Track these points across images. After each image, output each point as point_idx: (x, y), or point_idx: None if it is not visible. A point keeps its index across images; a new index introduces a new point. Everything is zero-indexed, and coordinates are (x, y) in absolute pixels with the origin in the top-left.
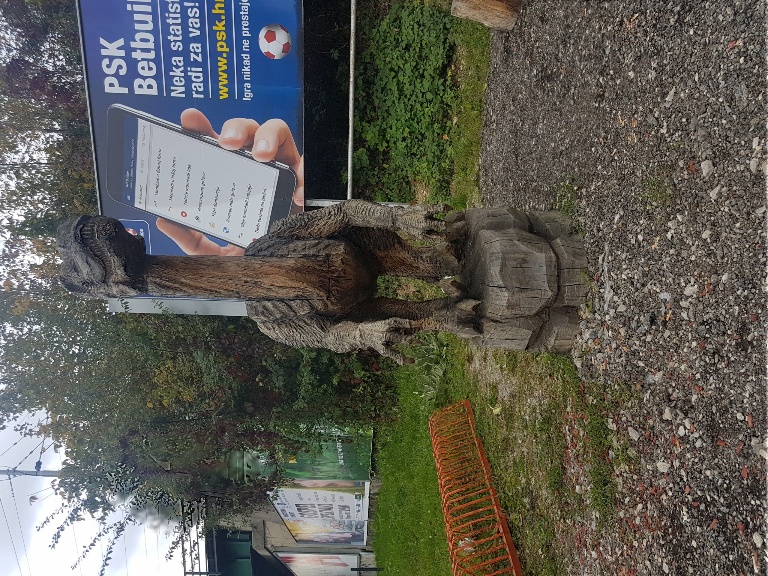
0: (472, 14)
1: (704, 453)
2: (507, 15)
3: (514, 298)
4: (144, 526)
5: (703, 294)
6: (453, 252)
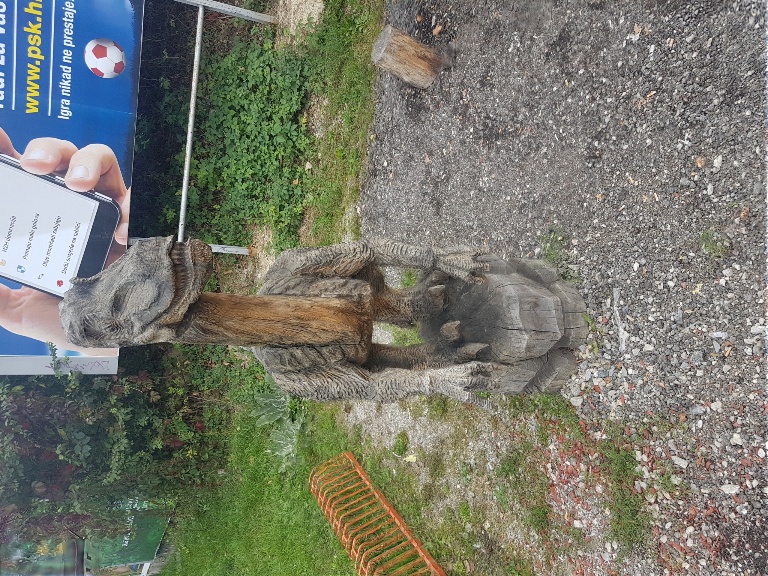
0: (396, 67)
1: None
2: (427, 74)
3: (531, 341)
4: None
5: None
6: (443, 296)
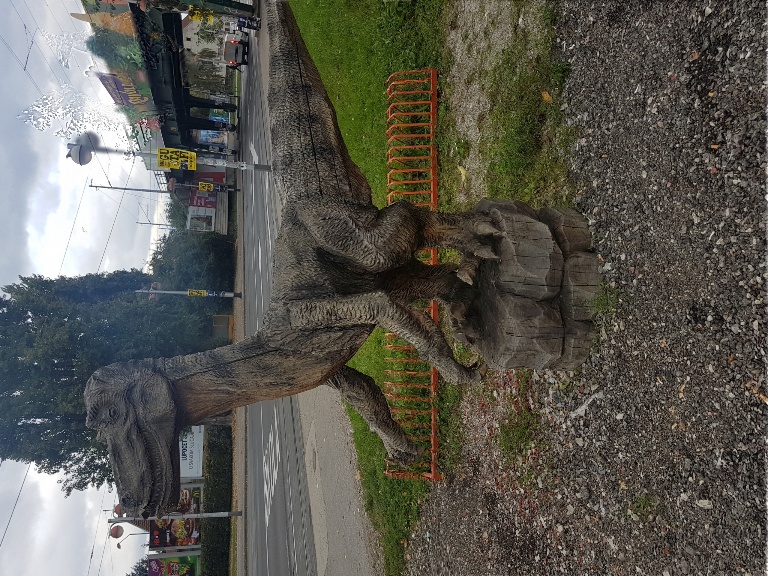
0: None
1: None
2: None
3: None
4: (91, 152)
5: (614, 567)
6: None
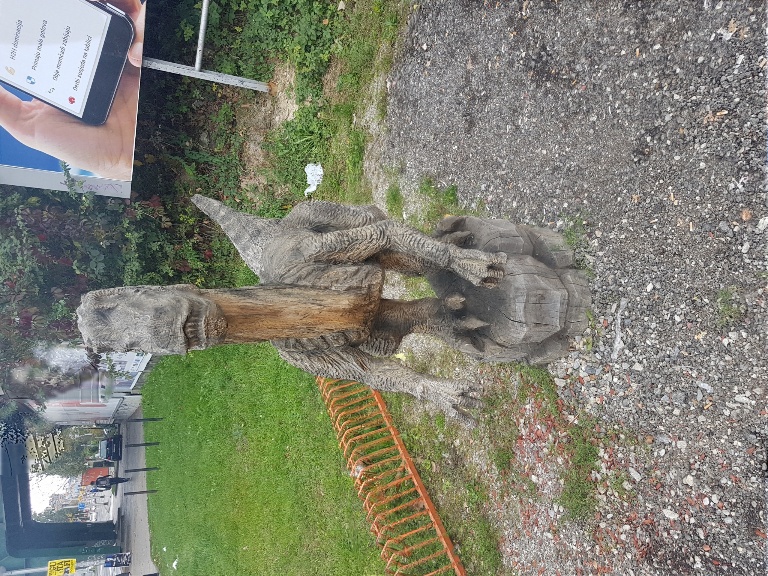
0: None
1: (735, 531)
2: None
3: (530, 332)
4: None
5: (763, 413)
6: None
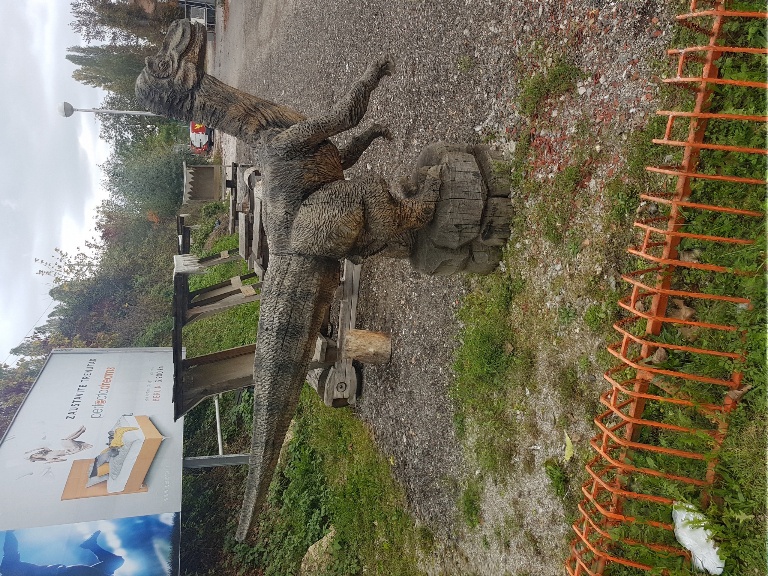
0: (360, 342)
1: None
2: (383, 340)
3: None
4: None
5: None
6: None
